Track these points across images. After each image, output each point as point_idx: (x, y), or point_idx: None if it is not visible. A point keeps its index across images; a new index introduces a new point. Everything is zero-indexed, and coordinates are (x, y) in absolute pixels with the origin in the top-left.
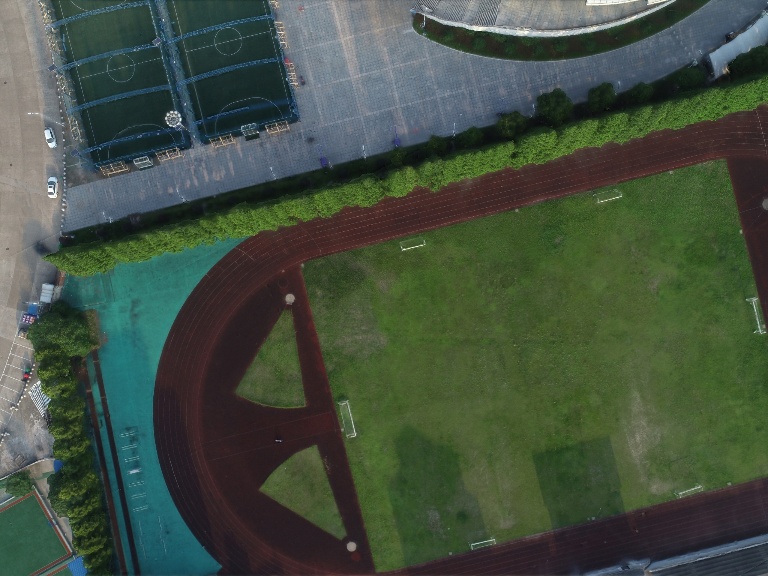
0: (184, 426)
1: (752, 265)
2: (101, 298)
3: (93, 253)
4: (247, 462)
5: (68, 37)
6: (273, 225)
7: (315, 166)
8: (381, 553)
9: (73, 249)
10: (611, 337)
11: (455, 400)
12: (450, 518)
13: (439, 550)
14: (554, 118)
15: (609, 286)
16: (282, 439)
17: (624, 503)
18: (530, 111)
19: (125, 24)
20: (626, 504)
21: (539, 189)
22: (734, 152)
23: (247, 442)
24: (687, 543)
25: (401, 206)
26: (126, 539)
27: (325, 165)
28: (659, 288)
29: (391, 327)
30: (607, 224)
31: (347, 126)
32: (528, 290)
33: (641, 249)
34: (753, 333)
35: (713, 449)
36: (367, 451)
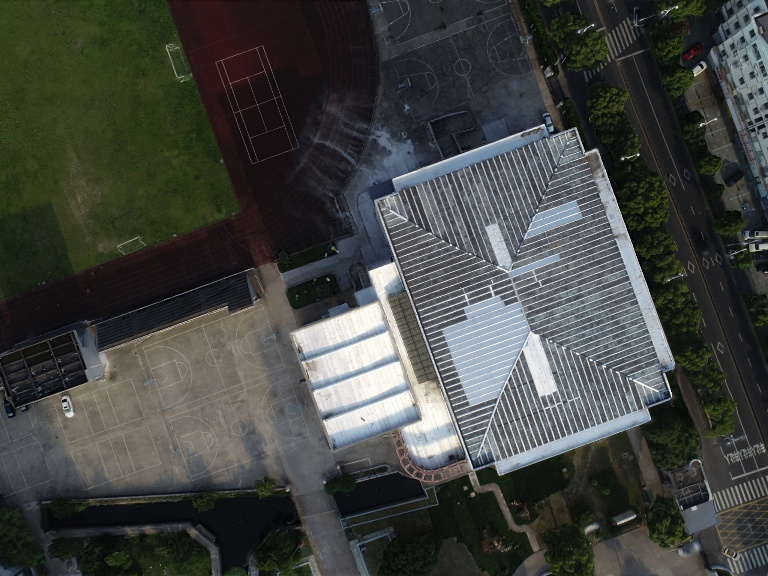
0: None
1: (172, 15)
2: None
3: None
4: None
5: None
6: None
7: None
8: None
9: None
10: (41, 100)
11: None
12: None
13: None
14: None
15: (33, 50)
16: None
17: (72, 264)
18: None
19: None
20: (74, 265)
21: None
22: None
23: None
24: (139, 298)
25: None
26: None
27: None
28: (83, 47)
29: None
30: None
31: None
32: None
33: (61, 10)
34: (180, 83)
35: (155, 202)
36: None
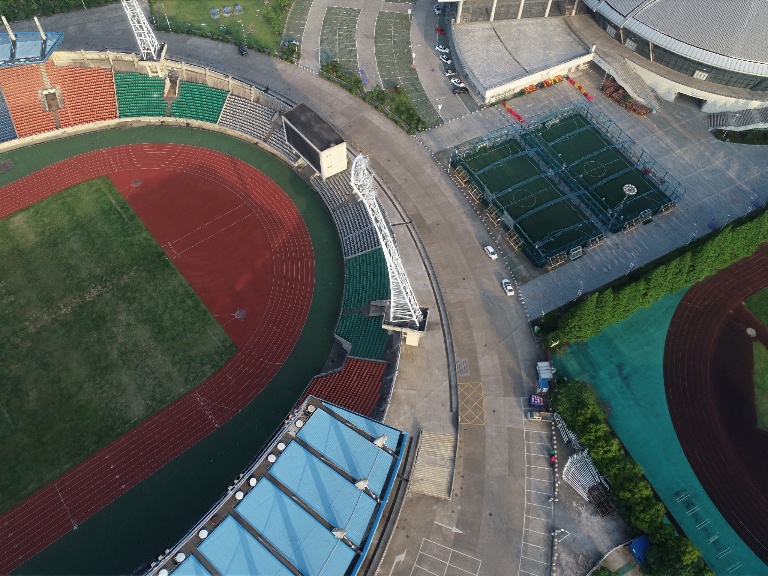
0: (730, 476)
1: None
2: (587, 370)
3: None
4: None
5: None
6: None
7: (707, 231)
8: None
9: None
10: None
11: None
12: None
13: None
14: None
15: None
16: None
17: None
18: None
19: (515, 173)
20: None
21: None
22: None
23: None
24: None
25: None
26: None
27: (715, 228)
28: None
29: None
30: None
31: (712, 201)
32: None
33: None
34: None
35: None
36: None
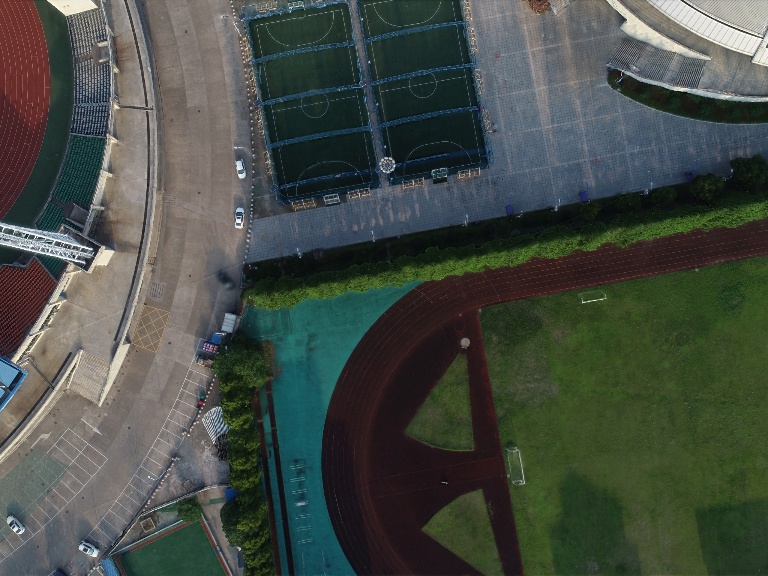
0: (352, 462)
1: None
2: (278, 330)
3: (295, 291)
4: (411, 501)
5: (264, 70)
6: None
7: (500, 213)
8: None
9: (279, 287)
10: None
11: (622, 454)
12: (609, 570)
13: None
14: (754, 185)
15: None
16: (448, 481)
17: None
18: (718, 172)
19: (322, 60)
20: None
21: (720, 250)
22: None
23: (413, 482)
24: None
25: (582, 258)
26: (286, 570)
27: (511, 213)
28: None
29: (564, 377)
30: None
31: (535, 175)
32: (702, 349)
33: None
34: None
35: None
36: (531, 498)
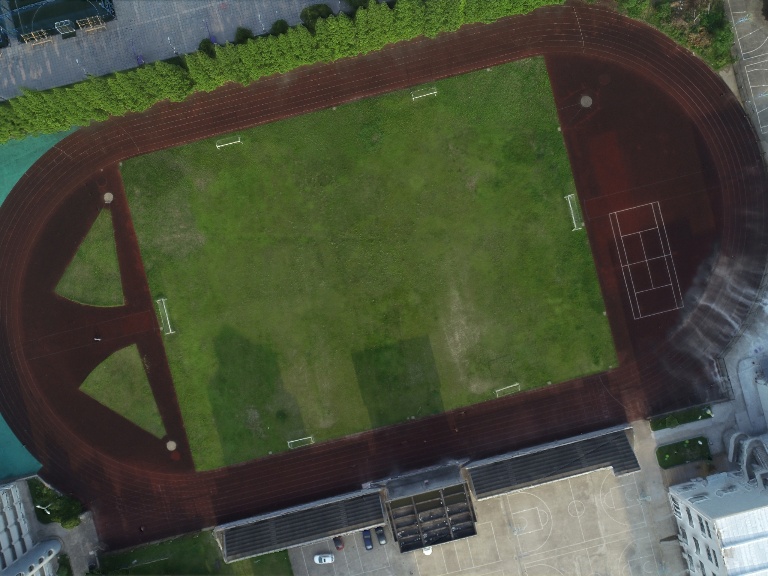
0: (4, 325)
1: (570, 162)
2: None
3: None
4: (67, 361)
5: None
6: (84, 120)
7: (132, 64)
8: (201, 452)
9: None
10: (429, 235)
11: (273, 299)
12: (269, 417)
13: (259, 449)
14: (356, 7)
15: (427, 184)
16: (101, 338)
17: (444, 402)
18: None
19: None
20: (446, 403)
21: (356, 87)
22: (552, 49)
23: (67, 341)
24: (507, 442)
25: (218, 104)
26: None
27: (141, 63)
28: (477, 186)
29: (209, 226)
30: (425, 122)
31: (163, 24)
32: (346, 188)
33: (459, 147)
34: (572, 231)
35: (533, 348)
36: (186, 350)
